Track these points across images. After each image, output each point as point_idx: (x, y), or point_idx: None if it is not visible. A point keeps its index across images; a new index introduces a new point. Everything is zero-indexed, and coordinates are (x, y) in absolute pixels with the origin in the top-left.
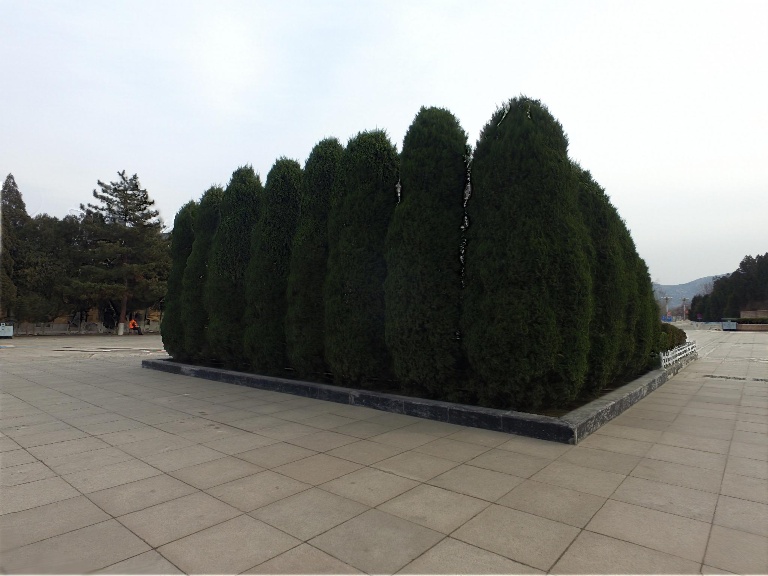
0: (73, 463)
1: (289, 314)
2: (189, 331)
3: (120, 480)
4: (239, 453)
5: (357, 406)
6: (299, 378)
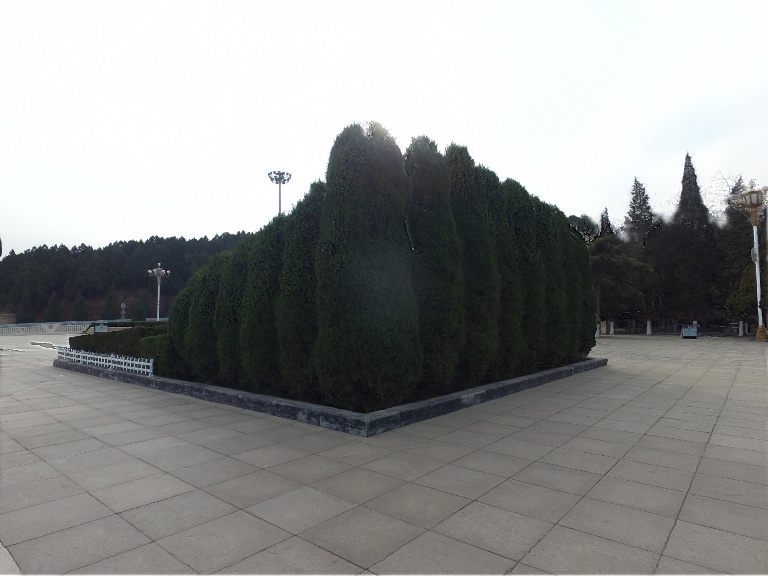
0: (759, 390)
1: (539, 319)
2: (460, 344)
3: (752, 385)
4: (693, 380)
5: (576, 374)
6: (529, 372)
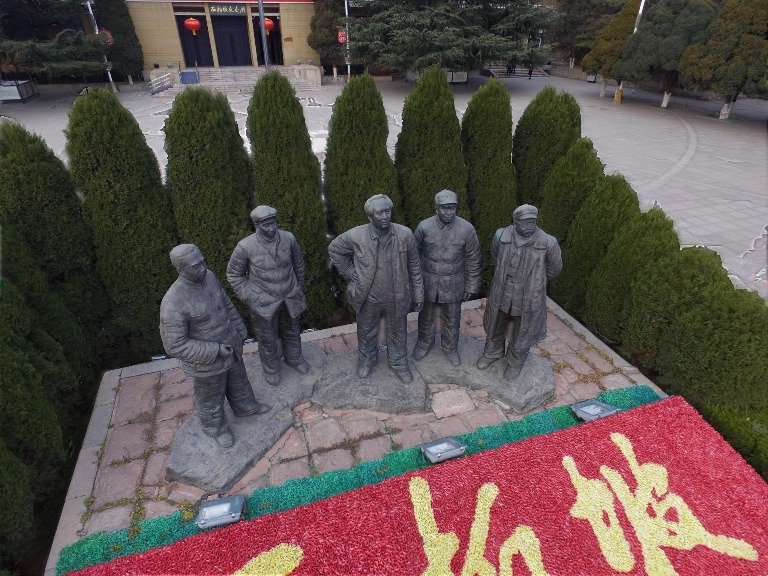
0: None
1: None
2: None
3: None
4: None
5: None
6: None
